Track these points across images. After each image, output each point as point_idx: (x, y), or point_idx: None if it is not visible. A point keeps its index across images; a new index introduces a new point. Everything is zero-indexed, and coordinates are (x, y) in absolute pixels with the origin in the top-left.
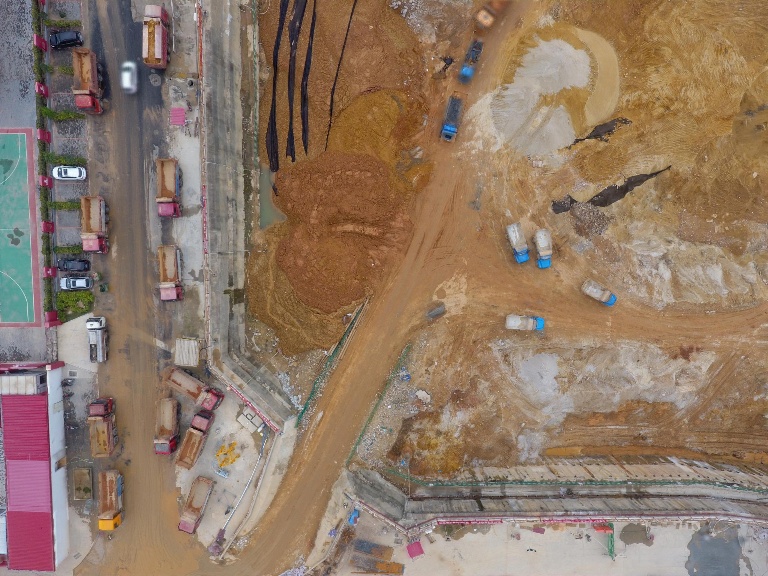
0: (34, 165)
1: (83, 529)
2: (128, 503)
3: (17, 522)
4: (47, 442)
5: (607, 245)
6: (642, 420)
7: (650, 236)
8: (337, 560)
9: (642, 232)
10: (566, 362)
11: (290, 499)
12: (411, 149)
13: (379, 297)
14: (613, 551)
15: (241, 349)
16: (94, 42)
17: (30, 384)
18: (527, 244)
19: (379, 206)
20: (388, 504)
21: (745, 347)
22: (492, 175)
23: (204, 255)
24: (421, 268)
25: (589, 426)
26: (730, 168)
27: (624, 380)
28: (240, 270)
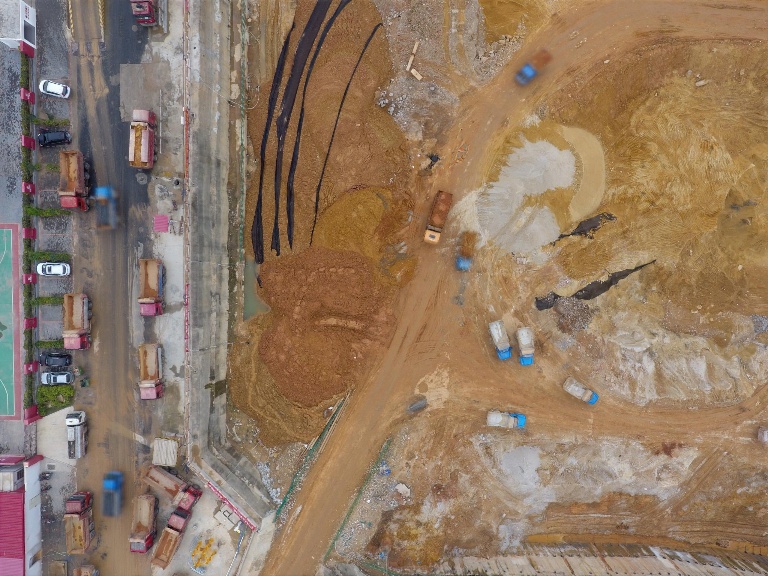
0: (19, 260)
1: None
2: None
3: None
4: (22, 540)
5: (590, 340)
6: (625, 509)
7: (634, 327)
8: None
9: (627, 322)
10: (548, 455)
11: None
12: (396, 244)
13: (361, 390)
14: None
15: (221, 440)
16: (82, 140)
17: (7, 481)
18: (510, 340)
19: (362, 301)
20: None
21: (728, 443)
22: (476, 271)
23: (186, 352)
24: (403, 362)
25: (571, 514)
26: (715, 261)
27: (606, 474)
28: (222, 362)
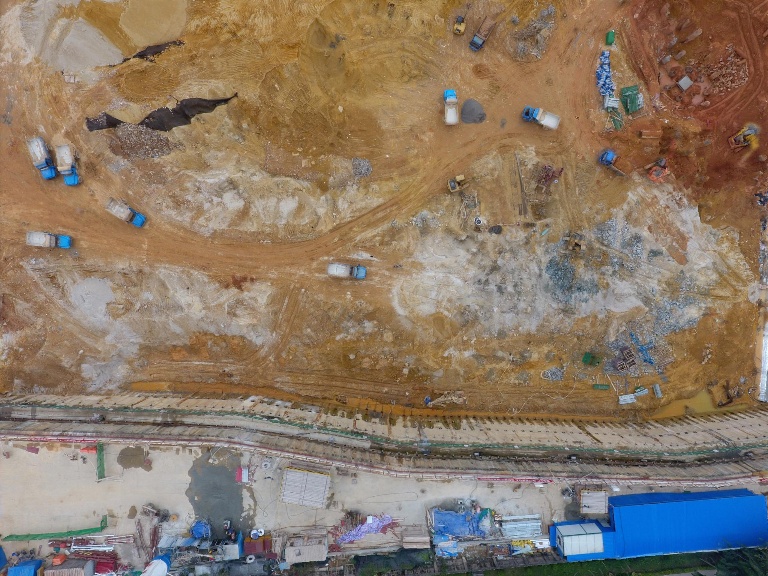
0: None
1: None
2: None
3: None
4: None
5: (155, 168)
6: (226, 356)
7: (229, 166)
8: None
9: (223, 162)
10: (119, 288)
11: None
12: None
13: None
14: None
15: None
16: None
17: None
18: None
19: None
20: None
21: (304, 280)
22: (23, 89)
23: None
24: None
25: (173, 361)
26: (309, 100)
27: (180, 309)
28: None
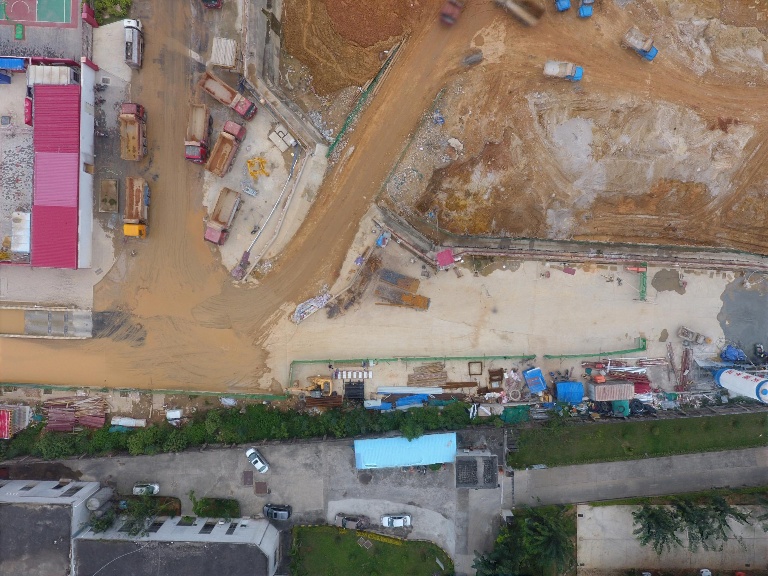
0: None
1: (106, 244)
2: (153, 220)
3: (42, 217)
4: (77, 133)
5: (649, 7)
6: (673, 210)
7: (691, 16)
8: (362, 289)
9: (683, 13)
10: (601, 129)
11: (317, 229)
12: None
13: (417, 38)
14: (645, 290)
15: (275, 82)
16: None
17: (64, 75)
18: None
19: None
20: (416, 238)
21: None
22: None
23: None
24: (460, 13)
25: (619, 214)
26: None
27: (659, 152)
28: (278, 0)
